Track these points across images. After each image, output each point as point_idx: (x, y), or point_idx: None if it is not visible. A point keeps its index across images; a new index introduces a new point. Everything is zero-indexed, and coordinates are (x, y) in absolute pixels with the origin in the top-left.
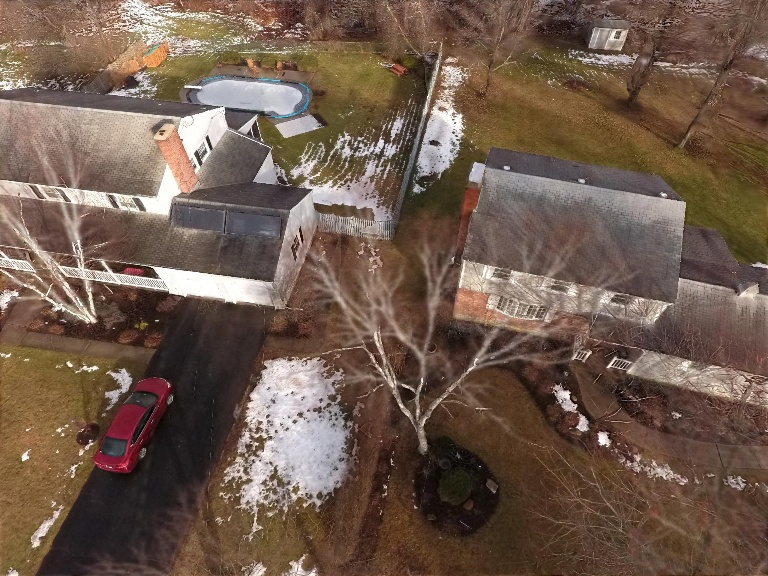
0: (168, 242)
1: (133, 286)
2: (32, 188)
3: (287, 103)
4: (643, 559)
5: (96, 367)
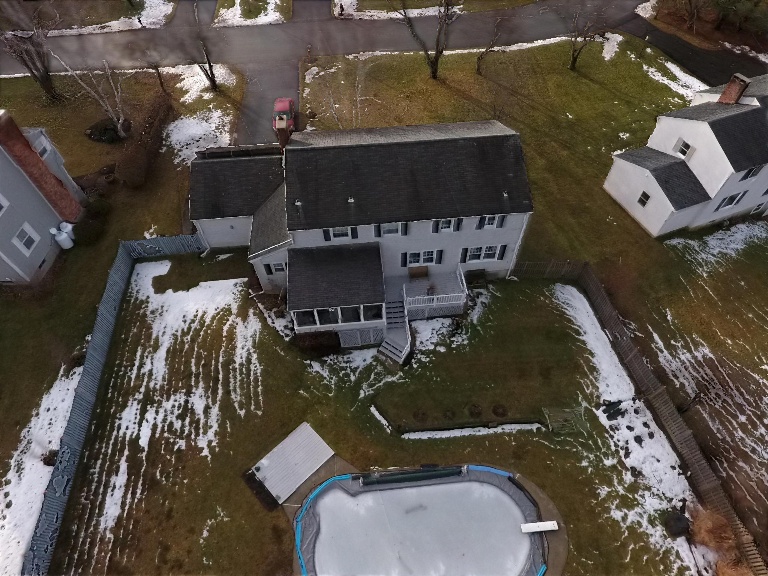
0: None
1: None
2: None
3: (338, 533)
4: (22, 124)
5: None
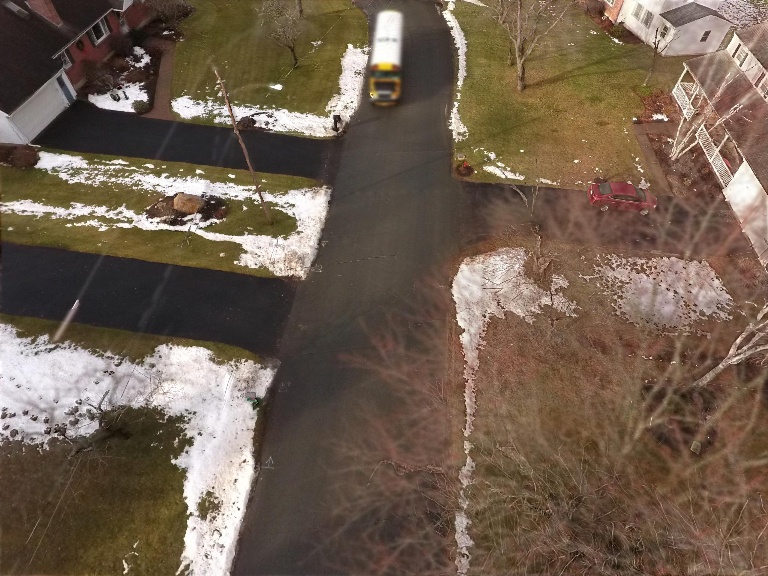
0: None
1: (713, 169)
2: (761, 75)
3: None
4: None
5: (643, 171)
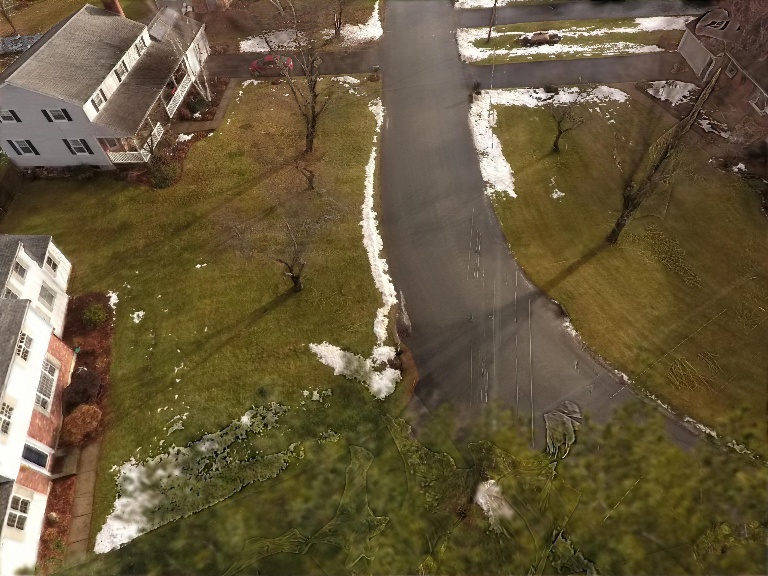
0: (171, 45)
1: (185, 94)
2: (115, 74)
3: None
4: None
5: (240, 91)
